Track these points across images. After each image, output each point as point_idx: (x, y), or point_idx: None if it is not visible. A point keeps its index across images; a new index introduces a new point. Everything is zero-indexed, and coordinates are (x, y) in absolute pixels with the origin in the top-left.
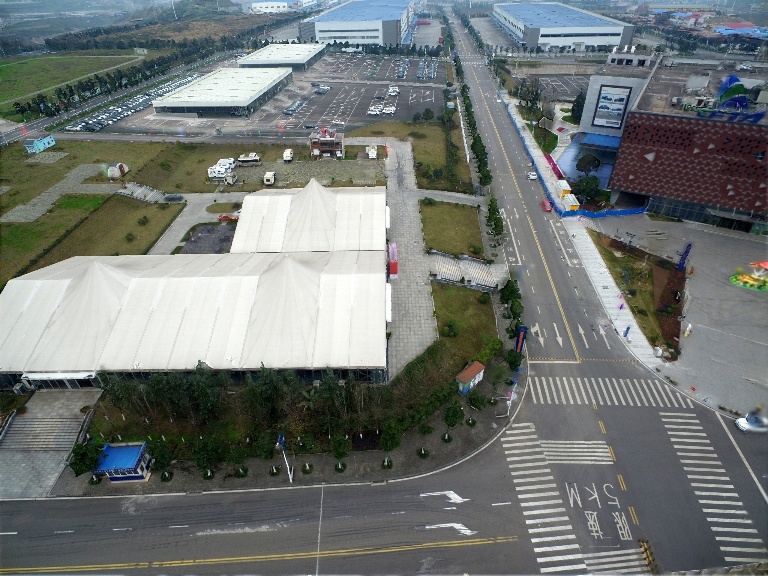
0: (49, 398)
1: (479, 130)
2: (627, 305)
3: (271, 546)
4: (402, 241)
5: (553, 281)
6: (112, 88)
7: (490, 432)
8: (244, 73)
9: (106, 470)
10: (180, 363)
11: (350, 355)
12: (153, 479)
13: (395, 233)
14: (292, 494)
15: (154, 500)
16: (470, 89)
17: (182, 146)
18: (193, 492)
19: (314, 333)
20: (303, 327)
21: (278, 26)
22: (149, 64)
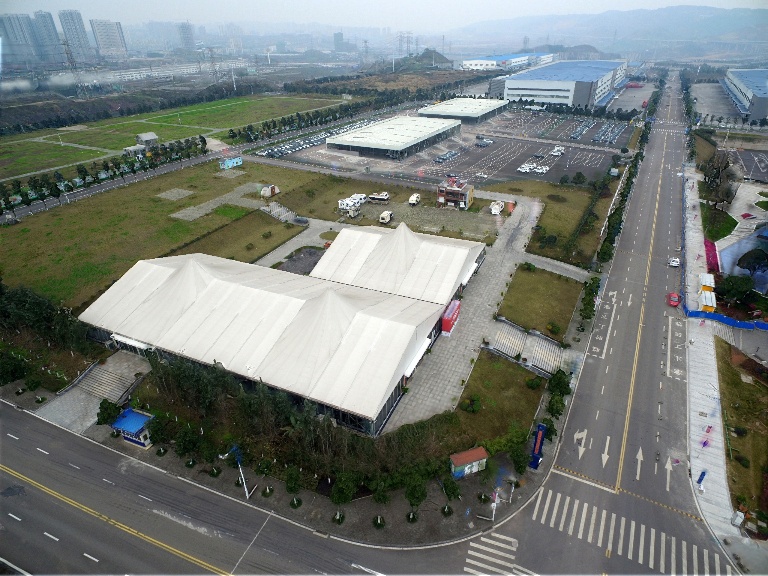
0: (124, 358)
1: (635, 202)
2: (723, 445)
3: (198, 549)
4: (476, 301)
5: (634, 387)
6: (305, 125)
7: (462, 530)
8: (416, 121)
9: (118, 428)
10: (212, 359)
11: (346, 396)
12: (152, 450)
13: (474, 291)
14: (242, 510)
15: (142, 468)
16: (650, 158)
17: (332, 178)
18: (172, 473)
19: (325, 365)
20: (319, 357)
21: (477, 82)
22: (344, 108)
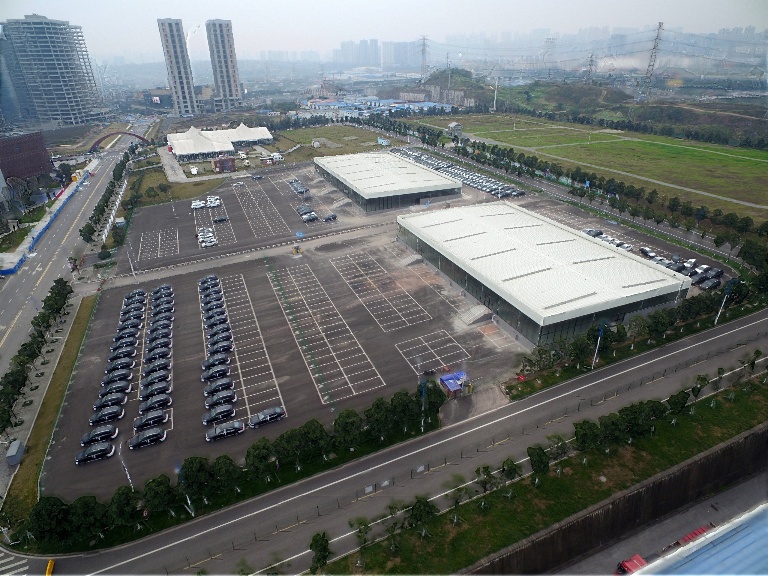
0: None
1: None
2: None
3: None
4: None
5: None
6: None
7: None
8: (403, 179)
9: None
10: None
11: None
12: None
13: None
14: None
15: None
16: None
17: None
18: None
19: None
20: None
21: None
22: (574, 173)
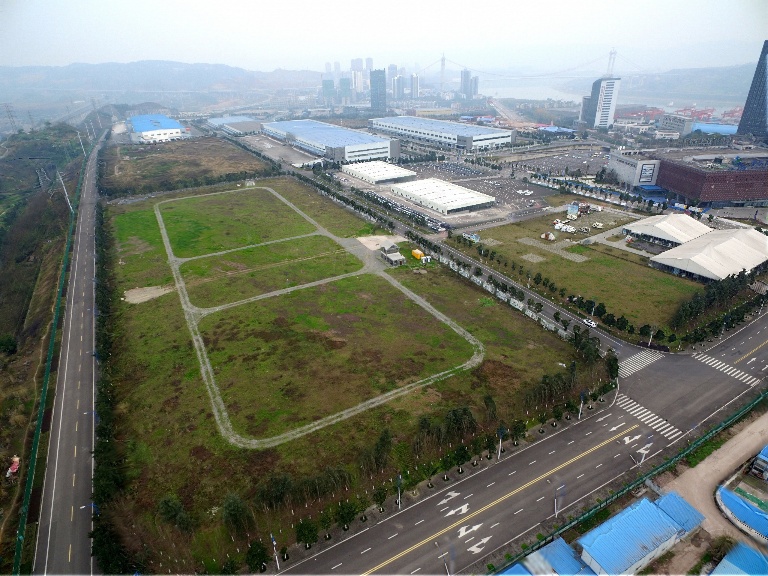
0: None
1: None
2: None
3: None
4: None
5: None
6: None
7: None
8: (421, 185)
9: None
10: (760, 261)
11: None
12: None
13: None
14: None
15: None
16: None
17: None
18: None
19: None
20: (763, 245)
21: None
22: None
